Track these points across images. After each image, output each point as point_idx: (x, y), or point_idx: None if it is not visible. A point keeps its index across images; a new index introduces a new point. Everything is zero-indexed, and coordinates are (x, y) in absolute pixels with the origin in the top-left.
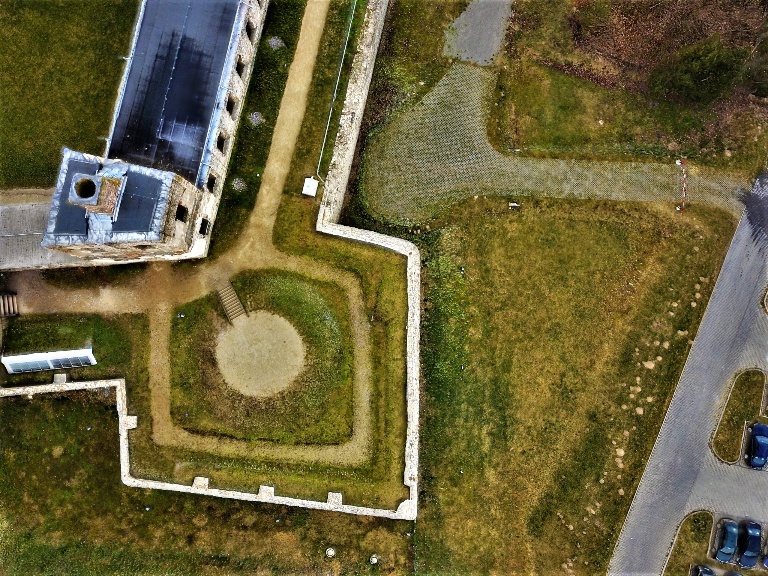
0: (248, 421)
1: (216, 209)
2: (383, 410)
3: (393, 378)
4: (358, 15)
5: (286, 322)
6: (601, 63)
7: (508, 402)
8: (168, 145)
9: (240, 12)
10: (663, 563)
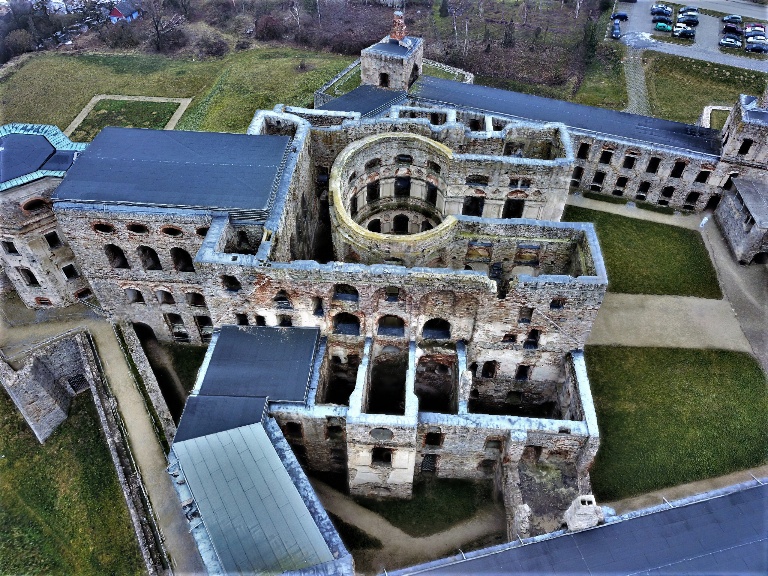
0: None
1: None
2: None
3: None
4: None
5: None
6: None
7: None
8: (701, 135)
9: None
10: None
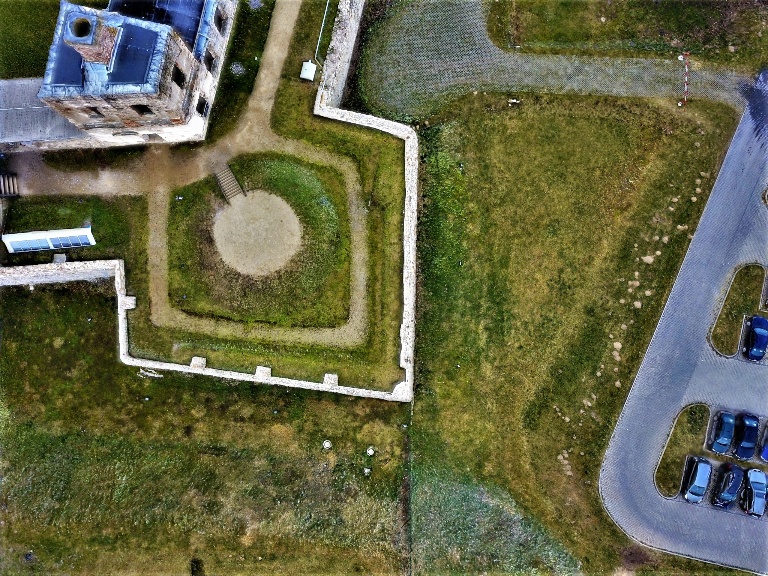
0: (245, 302)
1: (214, 92)
2: (380, 294)
3: (390, 262)
4: None
5: (283, 202)
6: None
7: (506, 297)
8: (165, 14)
9: None
10: (659, 454)
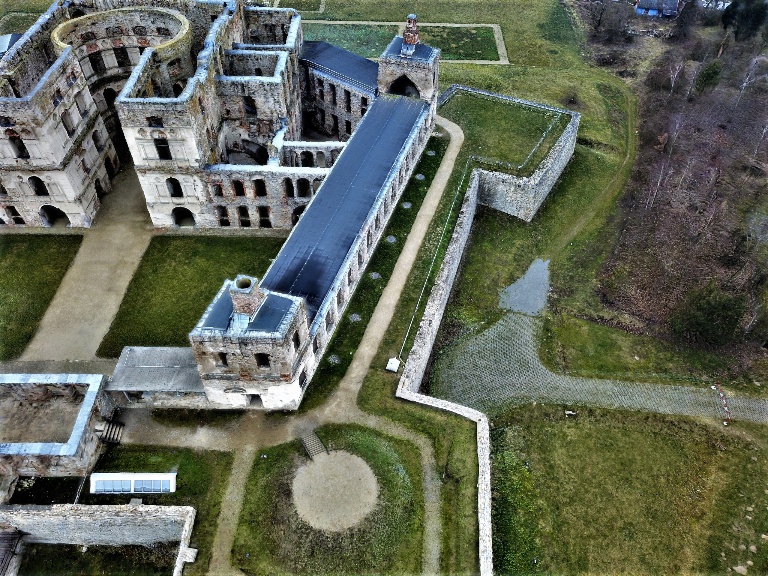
0: (311, 563)
1: (312, 374)
2: (454, 569)
3: (464, 535)
4: (436, 264)
5: (363, 462)
6: (627, 319)
7: None
8: None
9: (357, 241)
10: None
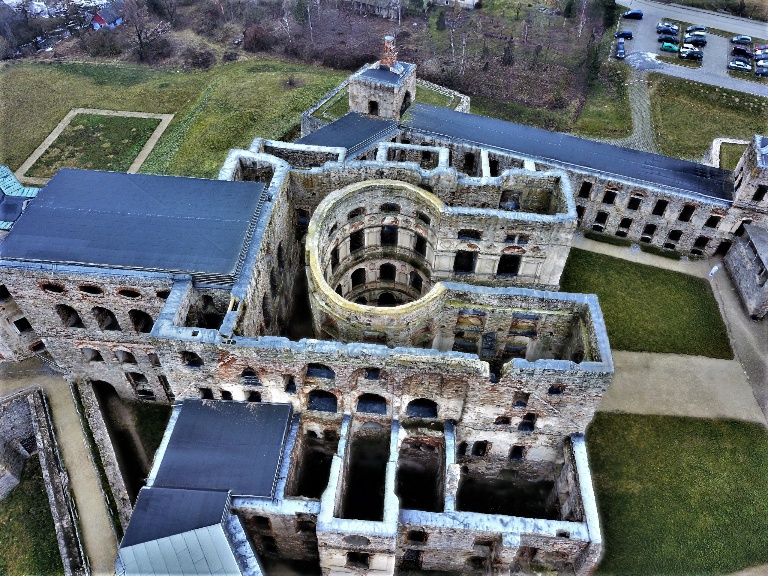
0: None
1: None
2: None
3: None
4: None
5: None
6: (574, 103)
7: None
8: None
9: None
10: None
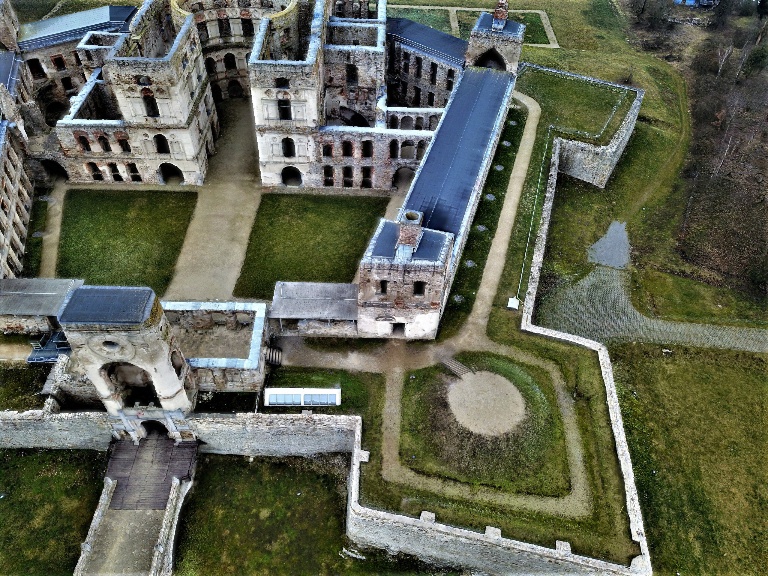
0: (473, 463)
1: (443, 310)
2: (597, 469)
3: (602, 442)
4: (536, 220)
5: (507, 380)
6: (707, 272)
7: (708, 507)
8: None
9: (473, 194)
10: None
